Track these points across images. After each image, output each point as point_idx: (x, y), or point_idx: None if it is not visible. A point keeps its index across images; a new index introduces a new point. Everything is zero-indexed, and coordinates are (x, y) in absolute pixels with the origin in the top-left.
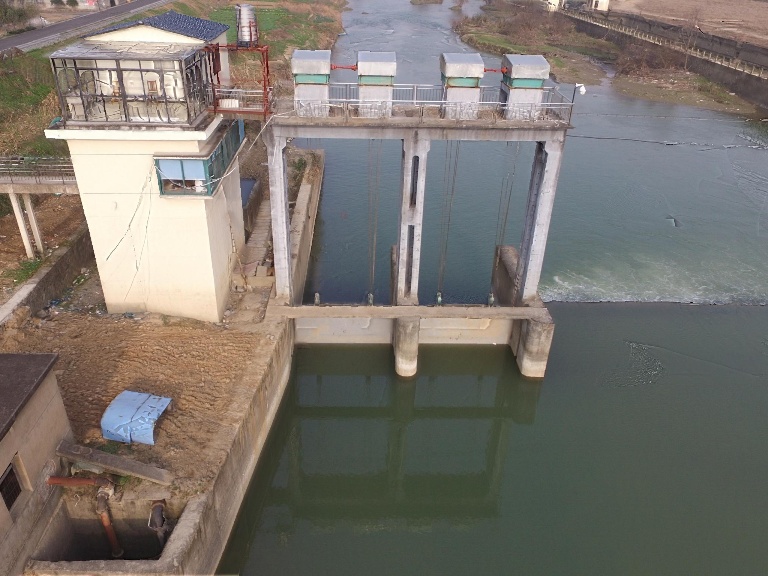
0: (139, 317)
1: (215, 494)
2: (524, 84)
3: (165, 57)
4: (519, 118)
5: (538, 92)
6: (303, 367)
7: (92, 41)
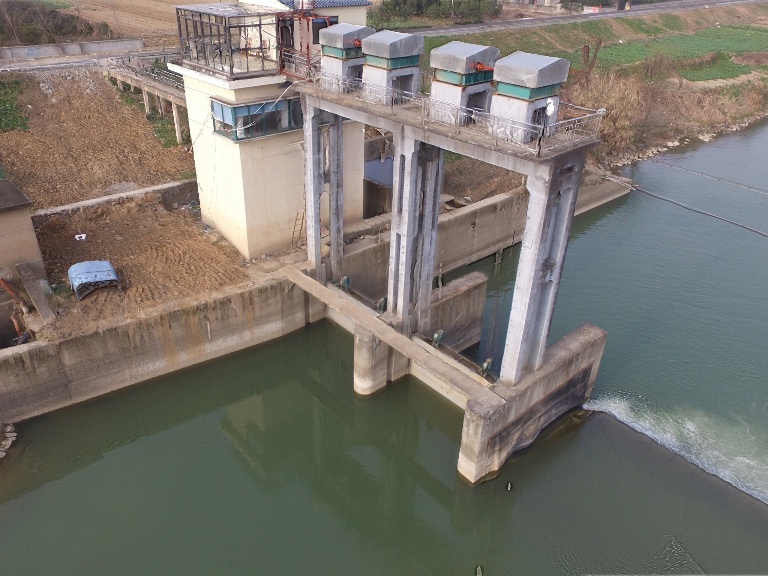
0: (209, 231)
1: (63, 350)
2: (511, 91)
3: (220, 13)
4: (501, 135)
5: (523, 105)
6: (333, 344)
7: (239, 2)
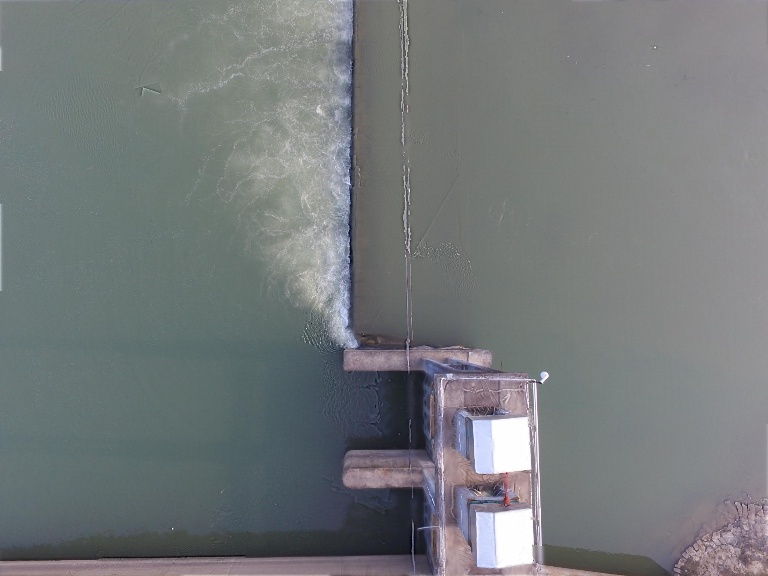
0: None
1: None
2: None
3: None
4: None
5: None
6: None
7: None
